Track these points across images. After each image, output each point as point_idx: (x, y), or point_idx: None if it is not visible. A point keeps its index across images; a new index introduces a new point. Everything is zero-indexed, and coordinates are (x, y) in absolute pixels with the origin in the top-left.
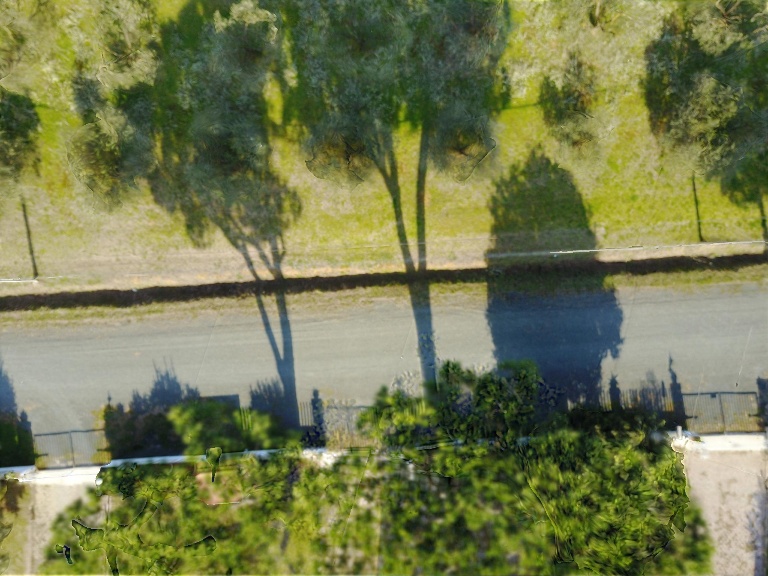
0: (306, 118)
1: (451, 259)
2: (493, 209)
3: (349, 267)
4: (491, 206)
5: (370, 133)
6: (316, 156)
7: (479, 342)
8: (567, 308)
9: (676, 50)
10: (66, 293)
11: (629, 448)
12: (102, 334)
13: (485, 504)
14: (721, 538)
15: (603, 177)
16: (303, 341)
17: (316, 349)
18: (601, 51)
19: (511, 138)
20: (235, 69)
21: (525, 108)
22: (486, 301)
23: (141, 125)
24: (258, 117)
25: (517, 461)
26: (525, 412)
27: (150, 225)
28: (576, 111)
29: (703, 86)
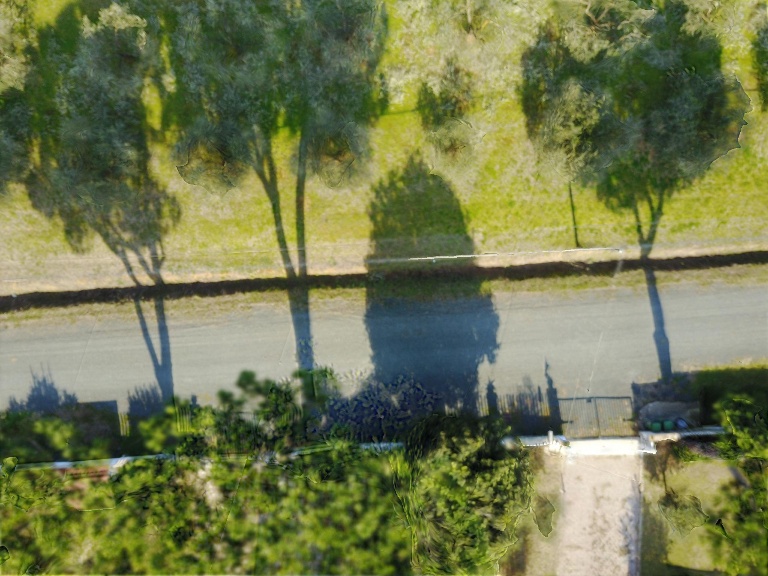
0: (184, 123)
1: (331, 264)
2: (372, 215)
3: (229, 272)
4: (370, 212)
5: (248, 139)
6: (190, 162)
7: (357, 347)
8: (444, 313)
9: (552, 57)
10: None
11: (466, 454)
12: None
13: (362, 509)
14: (595, 542)
15: (481, 183)
16: (181, 347)
17: (194, 355)
18: (478, 57)
19: (390, 144)
20: (106, 74)
21: (403, 114)
22: (364, 306)
23: (16, 130)
24: (136, 122)
25: (390, 466)
26: (402, 417)
27: (28, 230)
28: (453, 117)
29: (570, 93)
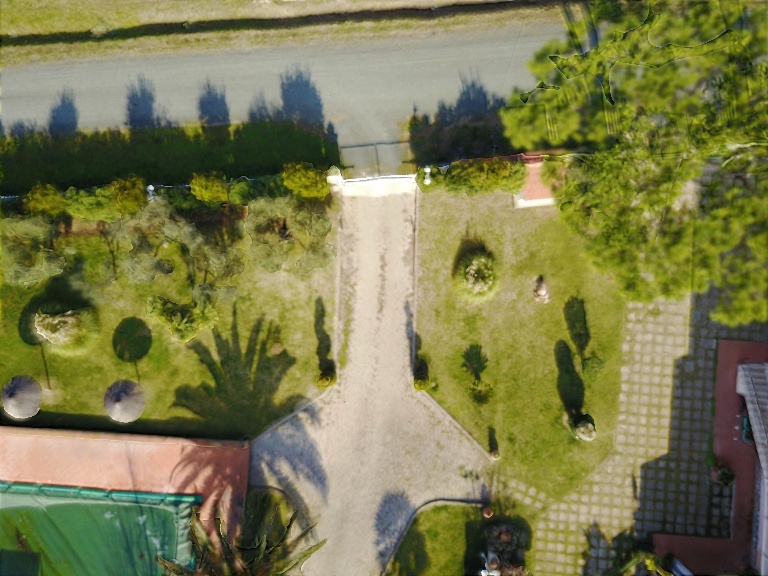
0: None
1: None
2: None
3: None
4: None
5: None
6: None
7: None
8: None
9: None
10: (366, 12)
11: None
12: (407, 46)
13: None
14: None
15: None
16: None
17: None
18: None
19: None
20: None
21: None
22: None
23: None
24: None
25: None
26: None
27: None
28: None
29: None
